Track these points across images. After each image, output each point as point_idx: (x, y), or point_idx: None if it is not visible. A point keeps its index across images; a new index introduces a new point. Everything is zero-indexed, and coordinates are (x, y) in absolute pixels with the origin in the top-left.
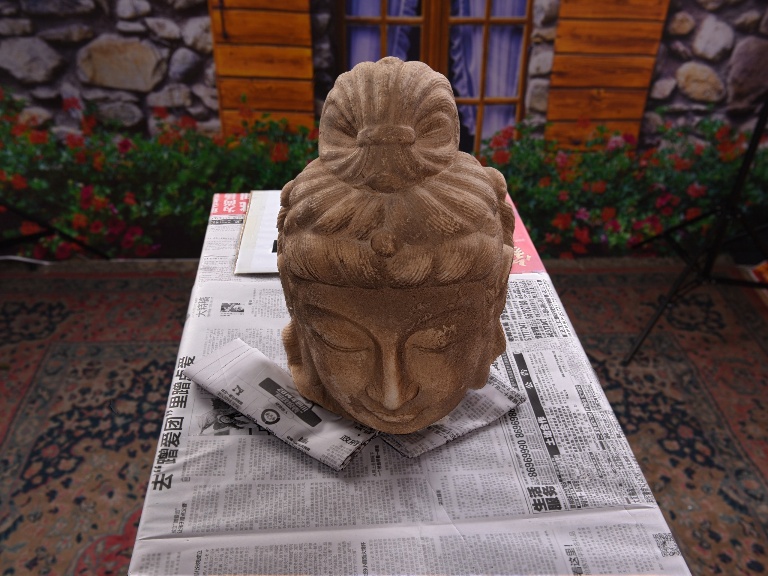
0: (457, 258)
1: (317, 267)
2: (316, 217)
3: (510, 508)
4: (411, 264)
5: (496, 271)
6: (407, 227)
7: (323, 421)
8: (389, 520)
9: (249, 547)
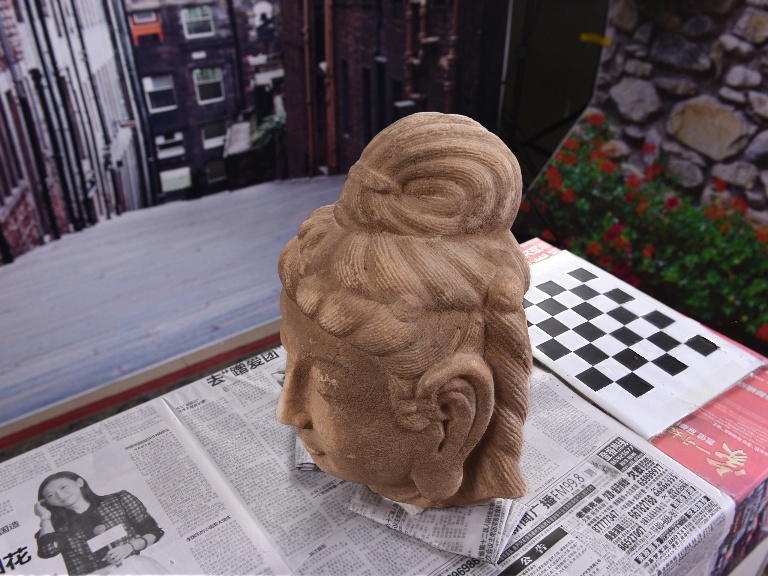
0: (335, 310)
1: None
2: None
3: None
4: (305, 292)
5: (407, 362)
6: (320, 259)
7: None
8: (267, 524)
9: (186, 452)
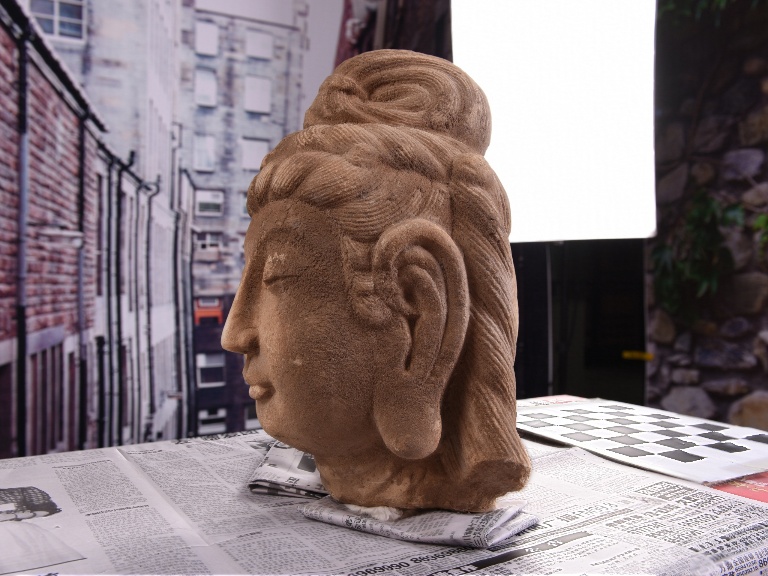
0: None
1: None
2: None
3: (261, 570)
4: None
5: (360, 215)
6: None
7: (314, 473)
8: (193, 516)
9: (122, 471)
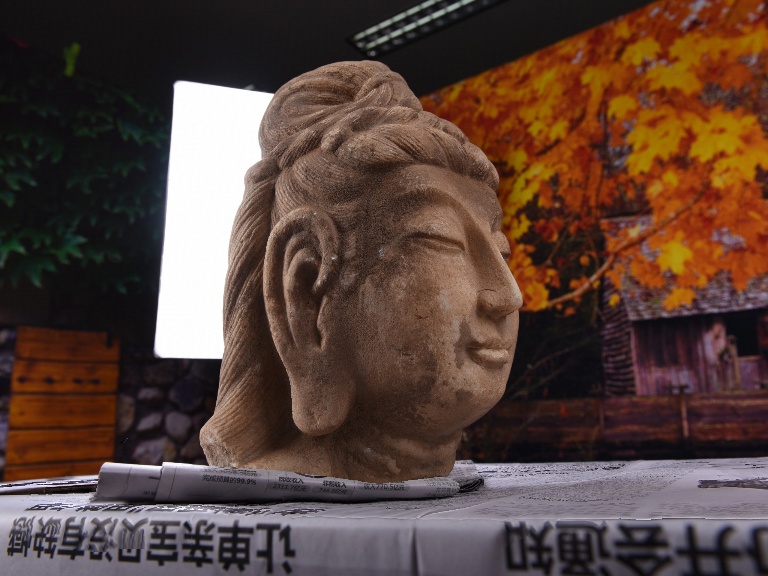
0: None
1: (418, 137)
2: (381, 114)
3: None
4: None
5: None
6: None
7: None
8: None
9: (546, 490)
